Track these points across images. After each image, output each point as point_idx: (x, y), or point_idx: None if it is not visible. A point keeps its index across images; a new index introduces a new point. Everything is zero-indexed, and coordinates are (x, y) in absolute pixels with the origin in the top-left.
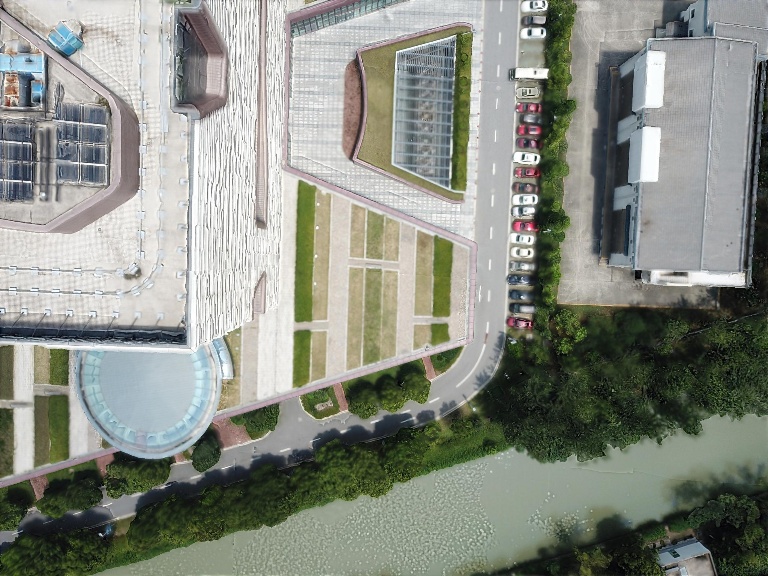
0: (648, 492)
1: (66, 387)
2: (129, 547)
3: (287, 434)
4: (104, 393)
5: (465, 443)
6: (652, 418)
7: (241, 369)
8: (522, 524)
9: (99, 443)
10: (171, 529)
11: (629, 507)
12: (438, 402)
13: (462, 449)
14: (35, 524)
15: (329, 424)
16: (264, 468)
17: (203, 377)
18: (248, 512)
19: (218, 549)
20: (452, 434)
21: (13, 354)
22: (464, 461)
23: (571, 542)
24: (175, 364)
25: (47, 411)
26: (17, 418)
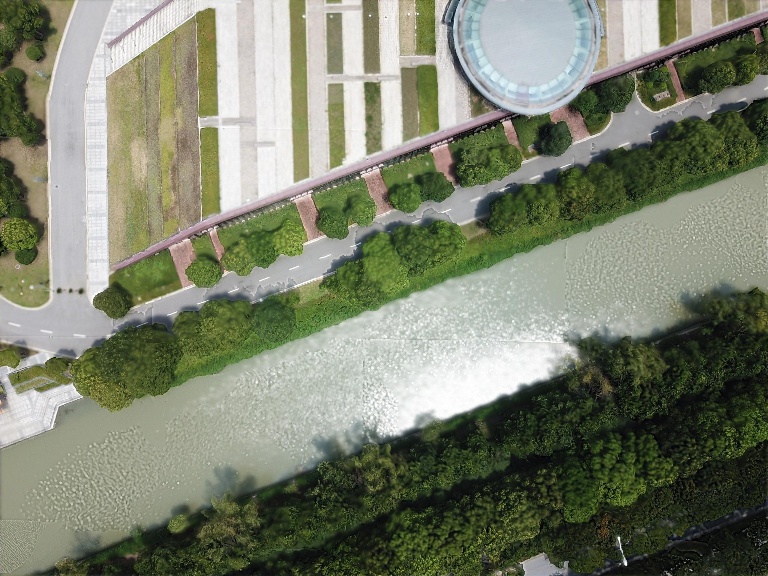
0: None
1: (432, 58)
2: (472, 252)
3: (625, 128)
4: (485, 47)
5: None
6: None
7: (607, 31)
8: None
9: (467, 114)
10: (546, 198)
11: None
12: None
13: None
14: (374, 234)
15: (666, 116)
16: (618, 149)
17: (582, 28)
18: (621, 179)
19: (550, 263)
20: None
21: (378, 27)
22: None
23: None
24: (556, 13)
25: (415, 82)
26: (384, 92)
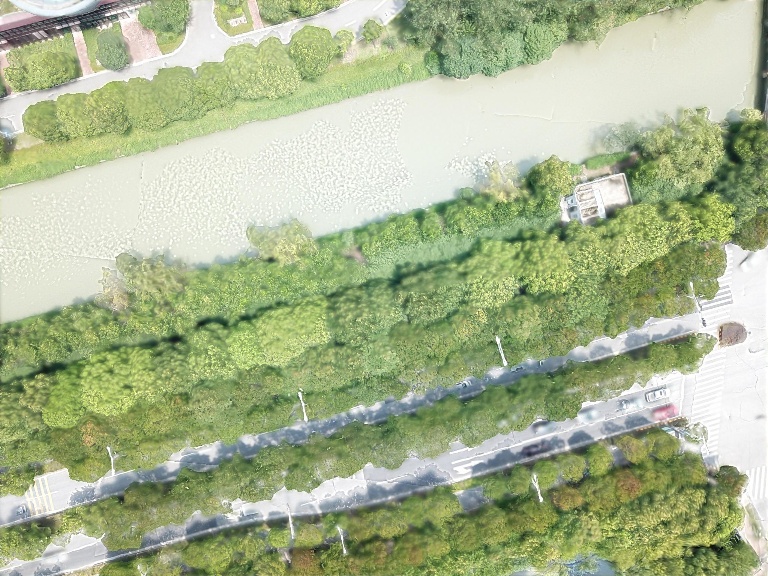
0: (567, 139)
1: None
2: (29, 160)
3: (199, 51)
4: None
5: (380, 66)
6: (561, 0)
7: None
8: (439, 171)
9: None
10: (67, 104)
11: (547, 149)
12: (354, 25)
13: (377, 71)
14: None
15: (242, 42)
16: None
17: None
18: (149, 93)
19: (125, 182)
20: (367, 57)
21: None
22: (379, 84)
23: (488, 184)
24: None
25: None
26: None
